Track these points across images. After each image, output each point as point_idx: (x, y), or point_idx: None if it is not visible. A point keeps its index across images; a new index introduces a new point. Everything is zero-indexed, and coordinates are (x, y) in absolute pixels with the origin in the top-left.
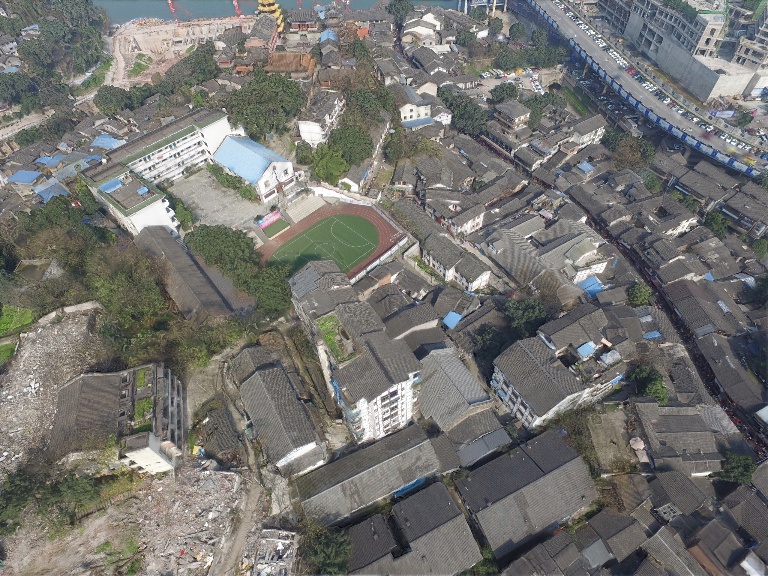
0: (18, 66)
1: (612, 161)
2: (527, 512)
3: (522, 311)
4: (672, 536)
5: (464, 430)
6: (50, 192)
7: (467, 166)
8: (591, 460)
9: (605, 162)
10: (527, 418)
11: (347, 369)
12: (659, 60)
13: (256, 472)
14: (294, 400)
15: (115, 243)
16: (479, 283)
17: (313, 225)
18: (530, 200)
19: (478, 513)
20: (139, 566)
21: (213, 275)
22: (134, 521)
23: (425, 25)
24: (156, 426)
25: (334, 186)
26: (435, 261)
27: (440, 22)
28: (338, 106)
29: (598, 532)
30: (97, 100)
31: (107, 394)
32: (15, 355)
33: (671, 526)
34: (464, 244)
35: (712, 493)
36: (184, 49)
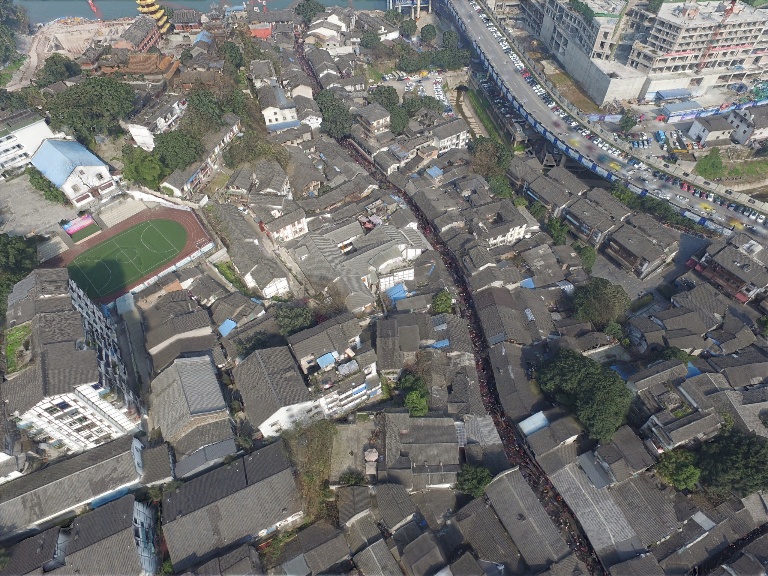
0: None
1: (470, 166)
2: (218, 525)
3: (290, 319)
4: (387, 549)
5: (189, 440)
6: None
7: None
8: (321, 471)
9: (463, 167)
10: (259, 429)
11: (15, 380)
12: (566, 63)
13: None
14: None
15: None
16: (275, 290)
17: (125, 230)
18: None
19: (164, 526)
20: None
21: None
22: None
23: (328, 26)
24: None
25: (154, 190)
26: None
27: (345, 23)
28: (180, 109)
29: (300, 545)
30: None
31: None
32: None
33: (393, 539)
34: (279, 250)
35: (450, 505)
36: None
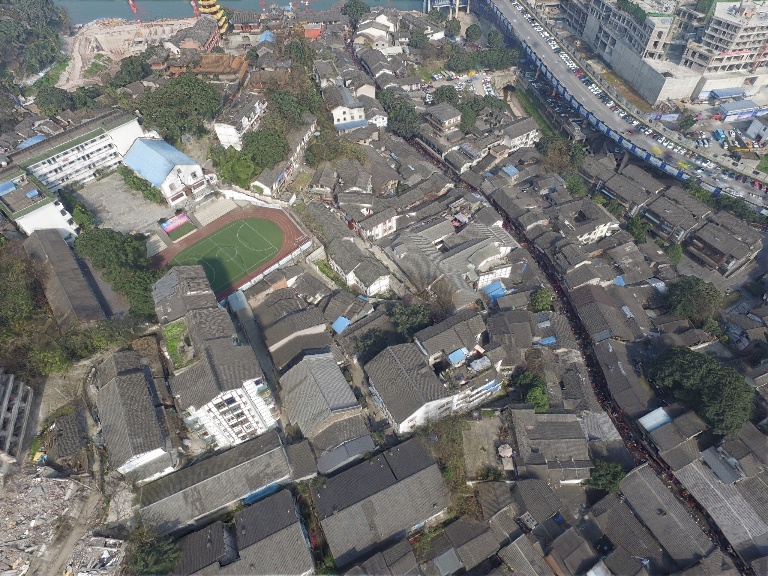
0: None
1: (542, 164)
2: (374, 520)
3: (407, 316)
4: (531, 544)
5: (328, 436)
6: None
7: (395, 169)
8: (457, 467)
9: (535, 165)
10: (394, 425)
11: (183, 376)
12: (613, 62)
13: (99, 479)
14: (148, 406)
15: (3, 246)
16: (378, 287)
17: (220, 228)
18: None
19: (322, 521)
20: None
21: (100, 279)
22: None
23: (377, 27)
24: None
25: (245, 189)
26: (337, 265)
27: (393, 24)
28: (260, 108)
29: (451, 540)
30: (37, 101)
31: None
32: None
33: (533, 534)
34: (372, 248)
35: (582, 501)
36: (144, 49)
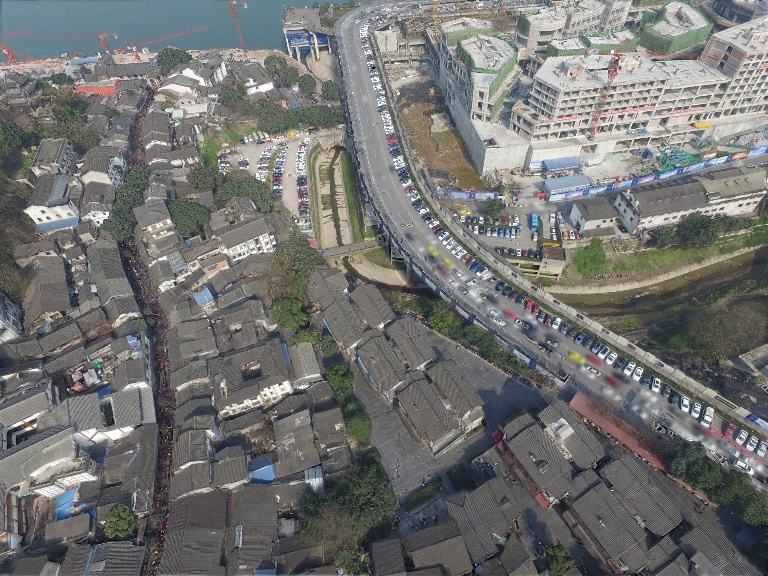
0: None
1: (265, 280)
2: None
3: None
4: None
5: None
6: None
7: None
8: None
9: (255, 282)
10: None
11: None
12: (455, 119)
13: None
14: None
15: None
16: None
17: None
18: None
19: None
20: None
21: None
22: None
23: (181, 82)
24: None
25: None
26: None
27: (203, 77)
28: None
29: None
30: None
31: None
32: None
33: None
34: None
35: None
36: None
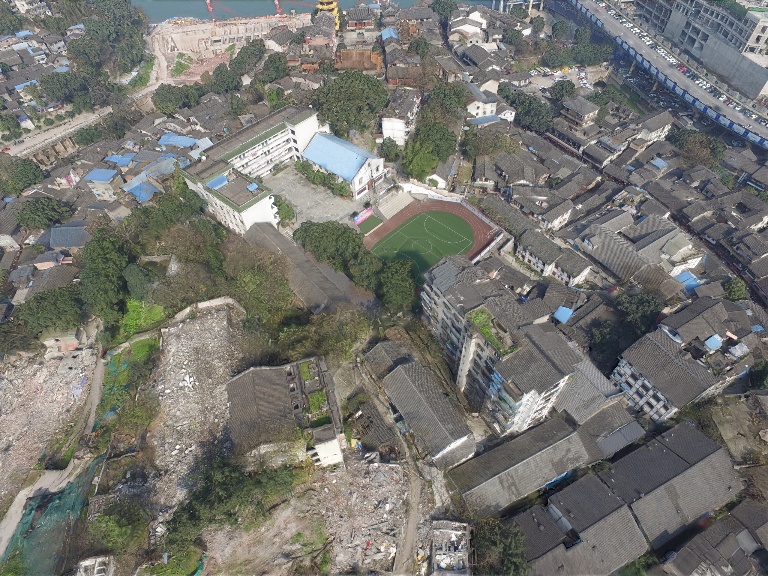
0: (67, 65)
1: (681, 157)
2: (679, 503)
3: (636, 305)
4: None
5: (599, 423)
6: (141, 190)
7: (538, 163)
8: None
9: (674, 158)
10: (658, 411)
11: (510, 361)
12: (704, 58)
13: (413, 465)
14: (439, 393)
15: (226, 239)
16: (579, 278)
17: (405, 221)
18: (609, 196)
19: (633, 504)
20: (329, 557)
21: (326, 271)
22: (318, 513)
23: (472, 23)
24: (333, 418)
25: (422, 183)
26: (532, 257)
27: (486, 20)
28: (416, 103)
29: (744, 523)
30: (156, 99)
31: (278, 387)
32: (161, 350)
33: None
34: (555, 240)
35: None
36: (223, 48)
